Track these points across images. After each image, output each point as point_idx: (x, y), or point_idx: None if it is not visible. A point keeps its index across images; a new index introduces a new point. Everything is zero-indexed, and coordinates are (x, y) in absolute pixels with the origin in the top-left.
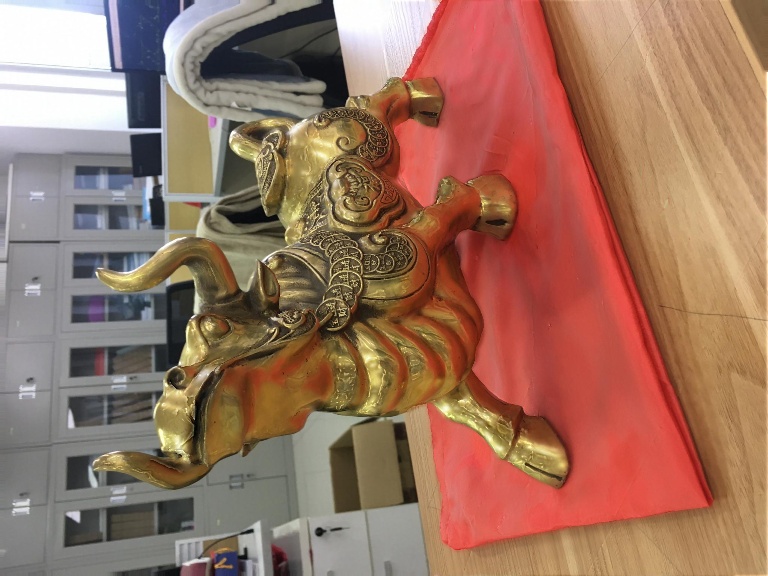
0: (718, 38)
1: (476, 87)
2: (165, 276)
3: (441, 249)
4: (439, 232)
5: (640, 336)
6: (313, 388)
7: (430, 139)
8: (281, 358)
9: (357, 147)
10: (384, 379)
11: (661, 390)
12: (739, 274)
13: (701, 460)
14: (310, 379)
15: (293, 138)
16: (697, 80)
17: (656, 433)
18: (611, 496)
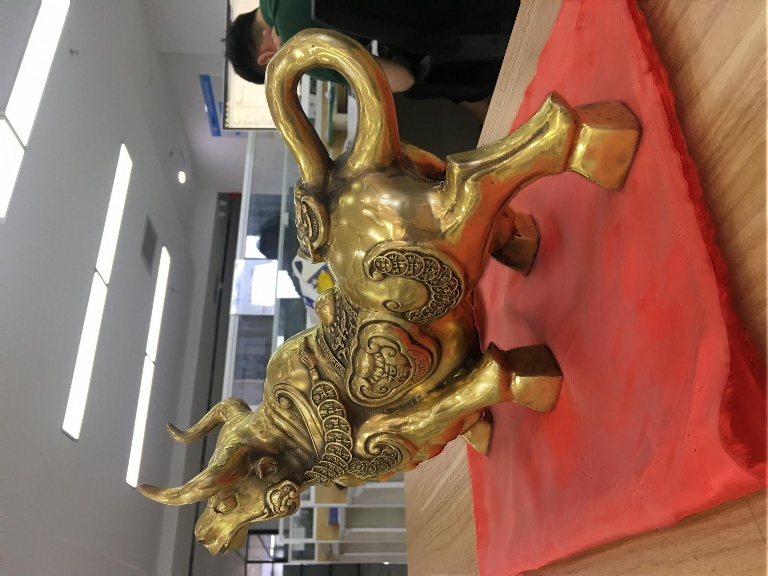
0: None
1: (614, 314)
2: None
3: None
4: None
5: None
6: None
7: None
8: None
9: (408, 311)
10: None
11: None
12: None
13: None
14: None
15: (336, 249)
16: None
17: None
18: (476, 510)
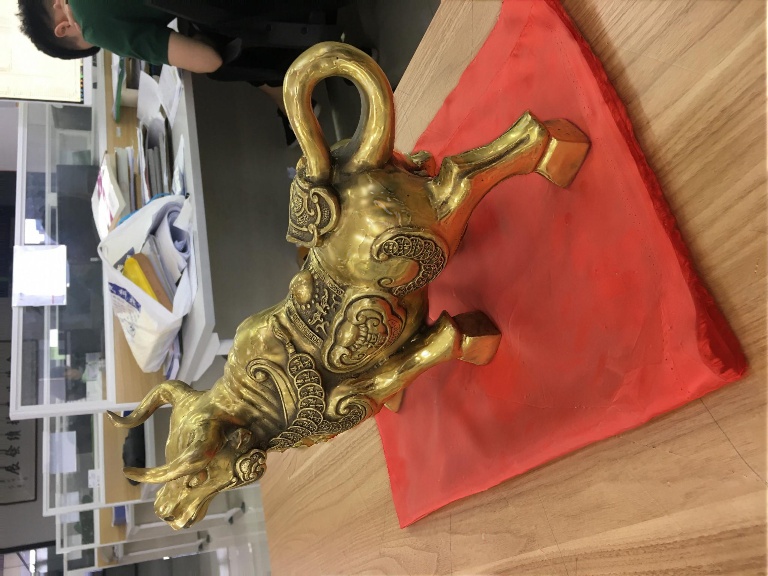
0: None
1: (563, 281)
2: None
3: None
4: None
5: None
6: None
7: None
8: None
9: (397, 286)
10: None
11: None
12: (462, 575)
13: None
14: None
15: None
16: None
17: None
18: (389, 461)
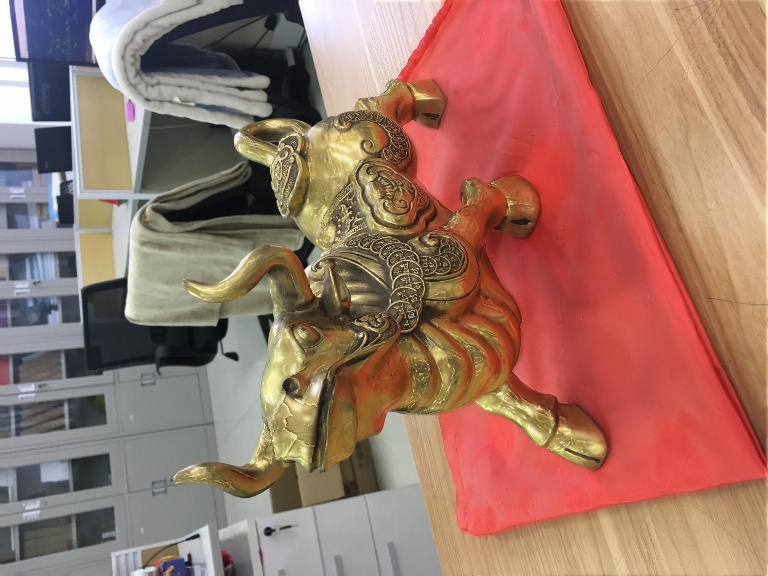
0: None
1: (486, 91)
2: (253, 285)
3: (480, 249)
4: (479, 233)
5: (693, 326)
6: (395, 389)
7: (429, 140)
8: (372, 362)
9: (381, 150)
10: (453, 377)
11: (717, 375)
12: None
13: (757, 436)
14: (393, 381)
15: (313, 141)
16: (746, 93)
17: (712, 414)
18: (661, 474)
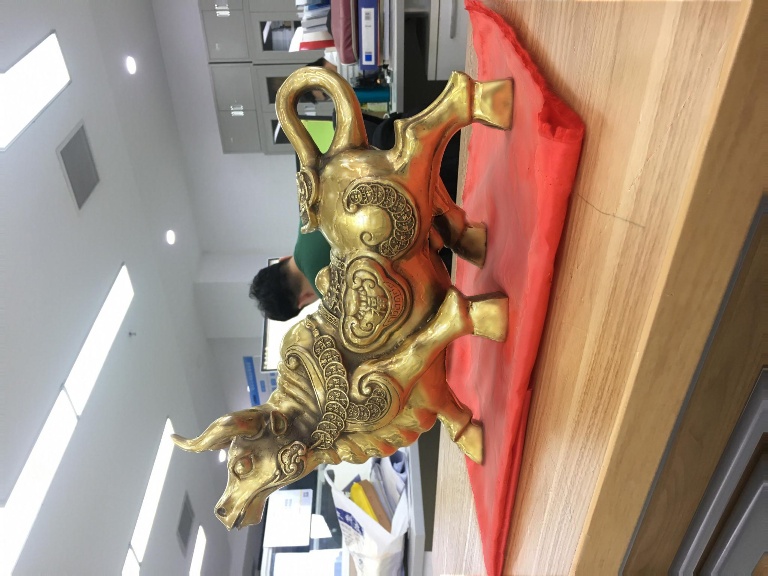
0: (561, 575)
1: (520, 203)
2: None
3: None
4: (420, 373)
5: (496, 536)
6: None
7: None
8: None
9: (380, 243)
10: None
11: (495, 556)
12: None
13: None
14: None
15: (325, 200)
16: None
17: None
18: (479, 519)
